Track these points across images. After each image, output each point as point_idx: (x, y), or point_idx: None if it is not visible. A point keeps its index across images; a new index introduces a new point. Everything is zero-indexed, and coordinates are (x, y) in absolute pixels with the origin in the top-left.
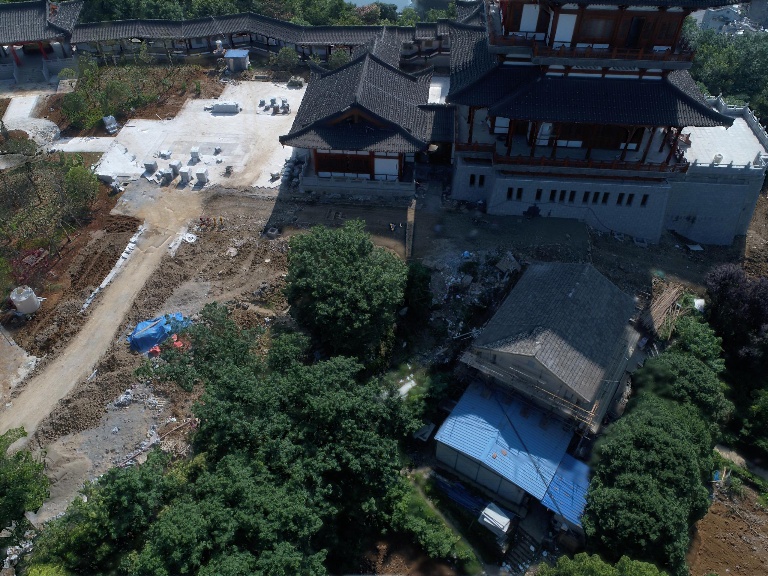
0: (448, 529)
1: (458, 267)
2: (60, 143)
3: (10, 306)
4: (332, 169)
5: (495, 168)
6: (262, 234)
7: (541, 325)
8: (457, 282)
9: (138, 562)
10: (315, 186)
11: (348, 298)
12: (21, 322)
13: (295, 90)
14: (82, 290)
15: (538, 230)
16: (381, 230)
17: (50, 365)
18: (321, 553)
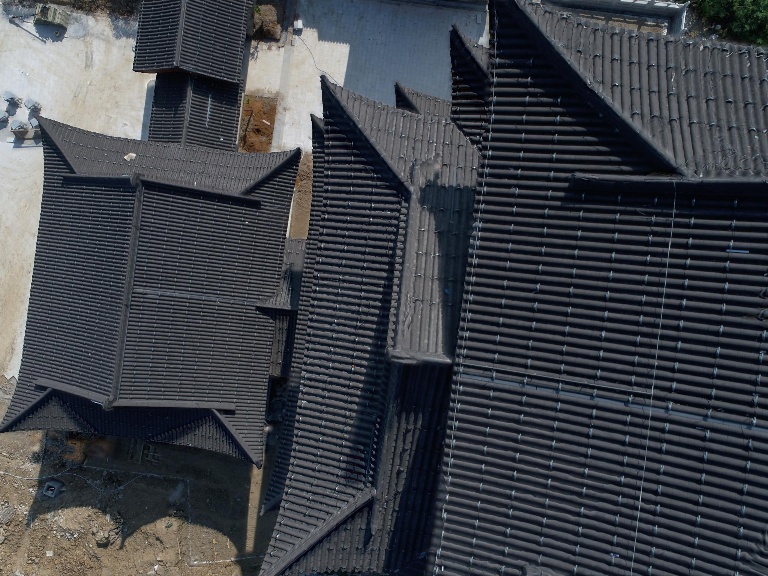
0: None
1: None
2: None
3: None
4: None
5: None
6: (36, 491)
7: None
8: None
9: None
10: None
11: None
12: None
13: (52, 44)
14: None
15: None
16: (212, 493)
17: None
18: None
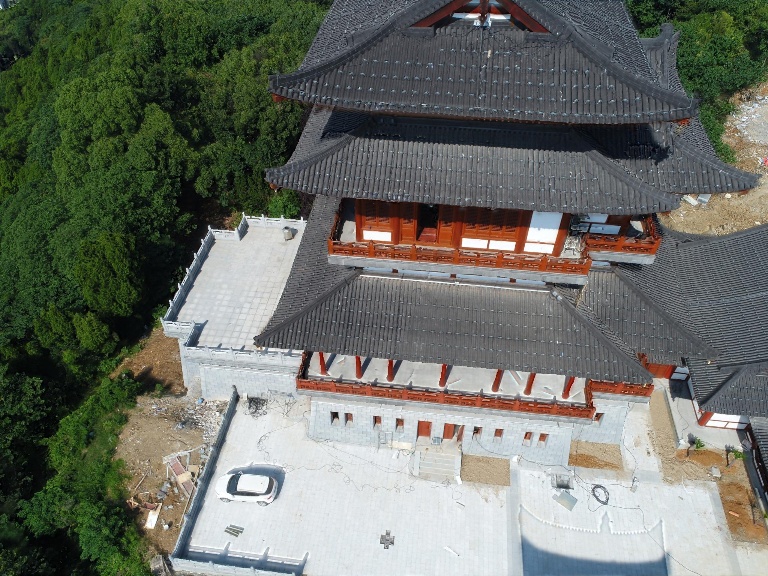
0: None
1: None
2: None
3: None
4: None
5: None
6: None
7: None
8: None
9: None
10: None
11: None
12: None
13: None
14: None
15: None
16: None
17: None
18: None
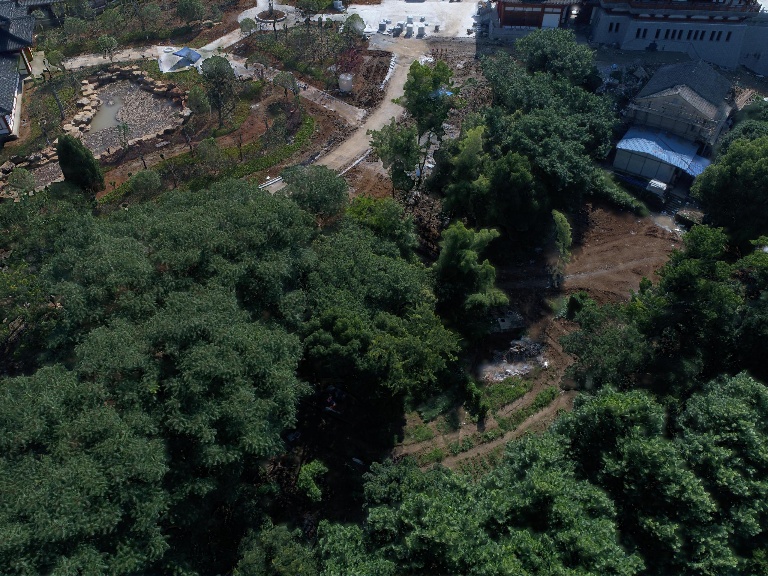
0: (628, 195)
1: (609, 74)
2: None
3: (334, 88)
4: (513, 23)
5: (632, 12)
6: (474, 59)
7: (678, 84)
8: (610, 82)
9: (508, 140)
10: (501, 34)
11: (569, 58)
12: (345, 95)
13: None
14: (375, 81)
15: (657, 57)
16: None
17: (376, 112)
18: (587, 156)
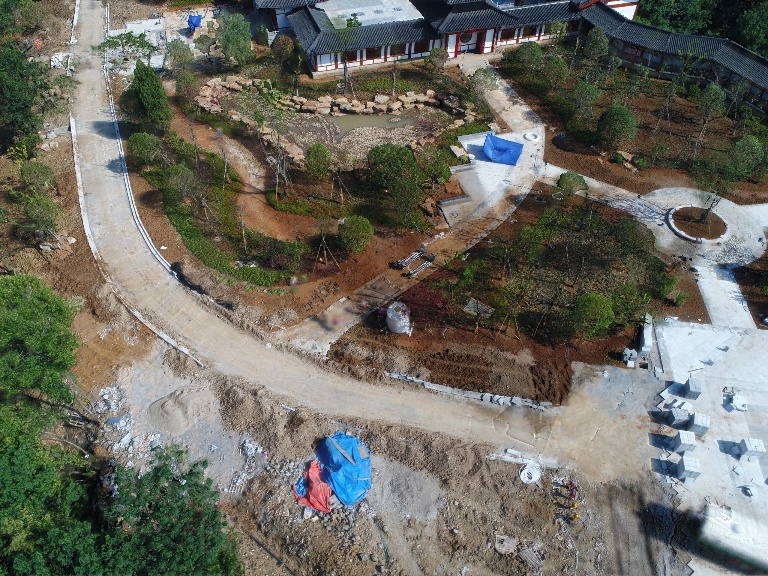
0: None
1: None
2: (717, 272)
3: None
4: None
5: None
6: None
7: None
8: None
9: None
10: None
11: None
12: (379, 324)
13: None
14: (422, 366)
15: None
16: None
17: (313, 365)
18: None
